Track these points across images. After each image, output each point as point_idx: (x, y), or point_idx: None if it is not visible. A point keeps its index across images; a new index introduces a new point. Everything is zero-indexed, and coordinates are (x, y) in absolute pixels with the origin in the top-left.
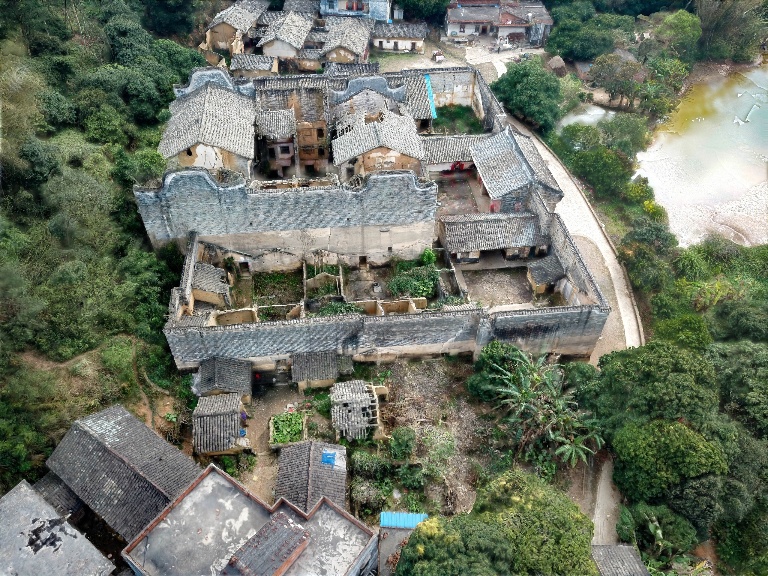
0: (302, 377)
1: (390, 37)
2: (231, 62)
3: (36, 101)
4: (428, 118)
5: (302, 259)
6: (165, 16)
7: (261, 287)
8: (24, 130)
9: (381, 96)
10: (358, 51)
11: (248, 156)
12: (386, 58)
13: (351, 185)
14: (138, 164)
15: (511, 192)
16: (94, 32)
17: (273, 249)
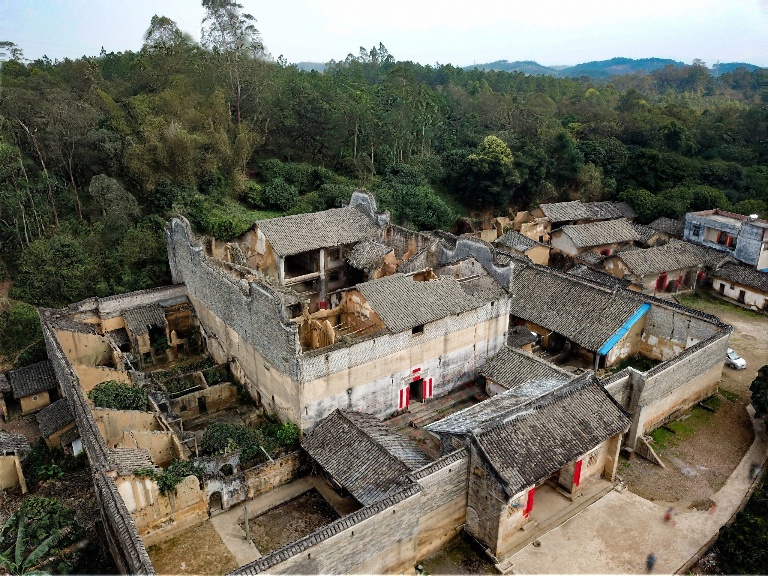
0: (41, 417)
1: (734, 282)
2: (501, 236)
3: (219, 165)
4: (592, 349)
5: (228, 361)
6: (471, 181)
7: (193, 366)
8: (187, 175)
9: (485, 272)
10: (638, 268)
11: (278, 252)
12: (712, 304)
13: (293, 308)
14: (211, 221)
15: (450, 435)
16: (361, 160)
17: (215, 334)
